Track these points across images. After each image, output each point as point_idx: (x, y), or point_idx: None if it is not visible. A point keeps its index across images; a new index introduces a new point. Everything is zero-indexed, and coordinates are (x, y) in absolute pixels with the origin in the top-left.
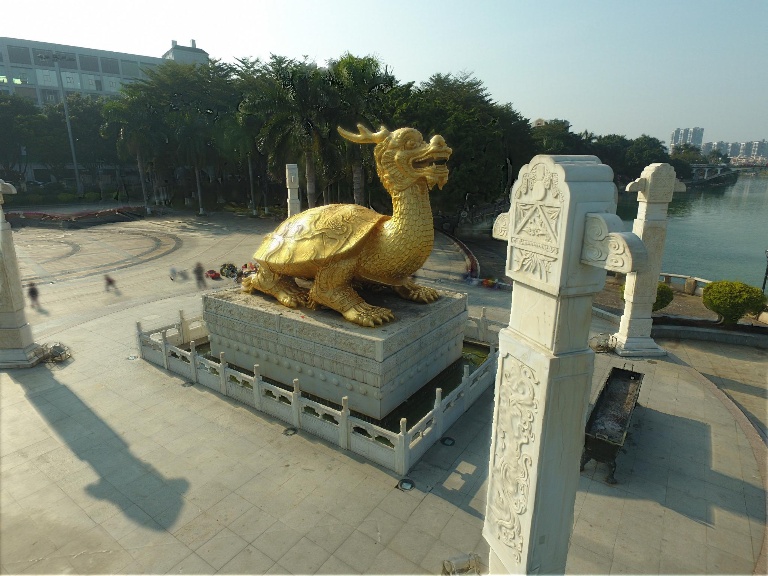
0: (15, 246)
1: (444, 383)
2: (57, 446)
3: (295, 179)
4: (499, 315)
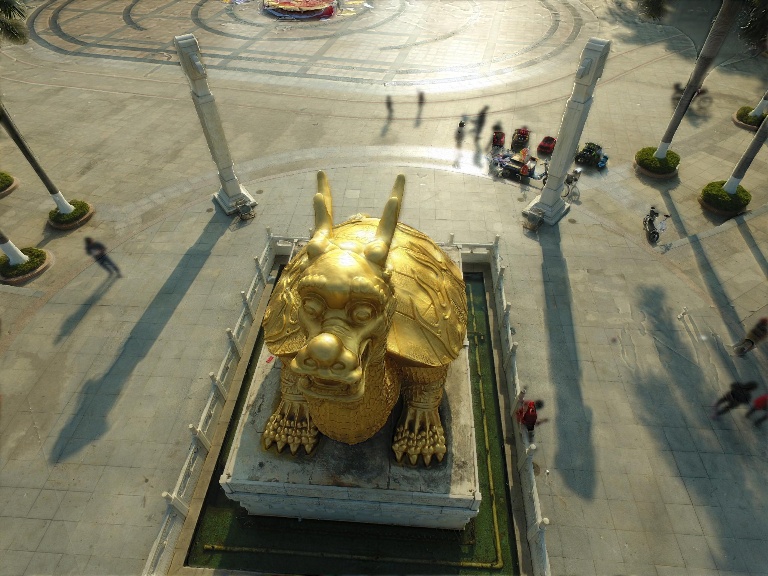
0: (436, 3)
1: (378, 539)
2: (135, 320)
3: (580, 74)
4: (672, 522)
